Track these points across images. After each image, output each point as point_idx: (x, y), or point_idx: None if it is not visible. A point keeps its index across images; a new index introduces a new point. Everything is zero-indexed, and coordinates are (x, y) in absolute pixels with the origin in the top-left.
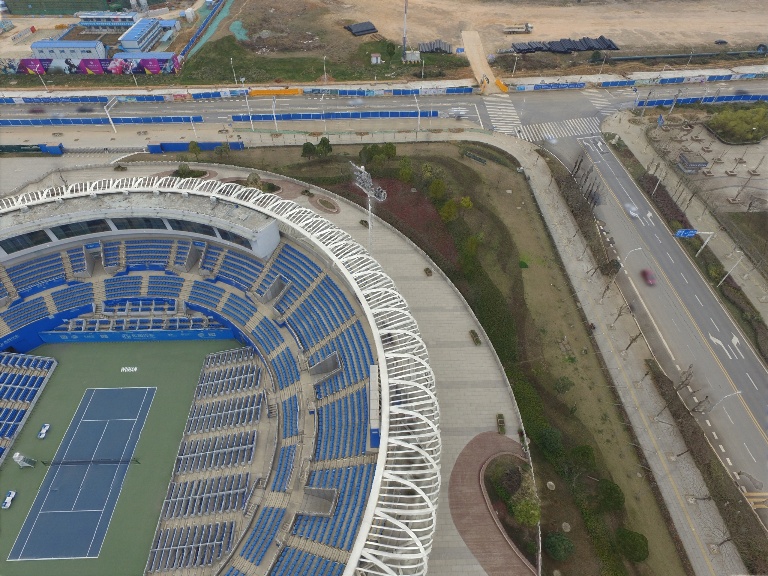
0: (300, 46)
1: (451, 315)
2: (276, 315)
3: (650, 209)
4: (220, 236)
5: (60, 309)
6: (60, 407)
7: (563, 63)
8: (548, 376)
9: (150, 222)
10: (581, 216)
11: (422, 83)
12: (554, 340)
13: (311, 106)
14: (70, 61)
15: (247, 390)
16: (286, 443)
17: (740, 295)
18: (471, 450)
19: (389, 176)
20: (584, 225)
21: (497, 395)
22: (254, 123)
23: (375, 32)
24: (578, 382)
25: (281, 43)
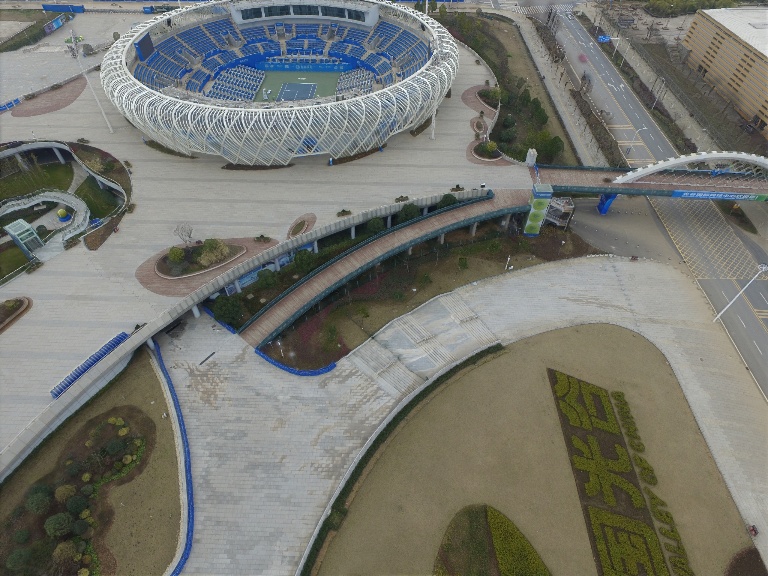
0: None
1: (466, 57)
2: None
3: (592, 41)
4: (348, 17)
5: (265, 51)
6: (273, 87)
7: None
8: (515, 89)
9: (311, 10)
10: (548, 41)
11: None
12: None
13: None
14: None
15: None
16: None
17: (631, 70)
18: (472, 88)
19: None
20: (549, 44)
21: (487, 77)
22: None
23: None
24: (531, 92)
25: None
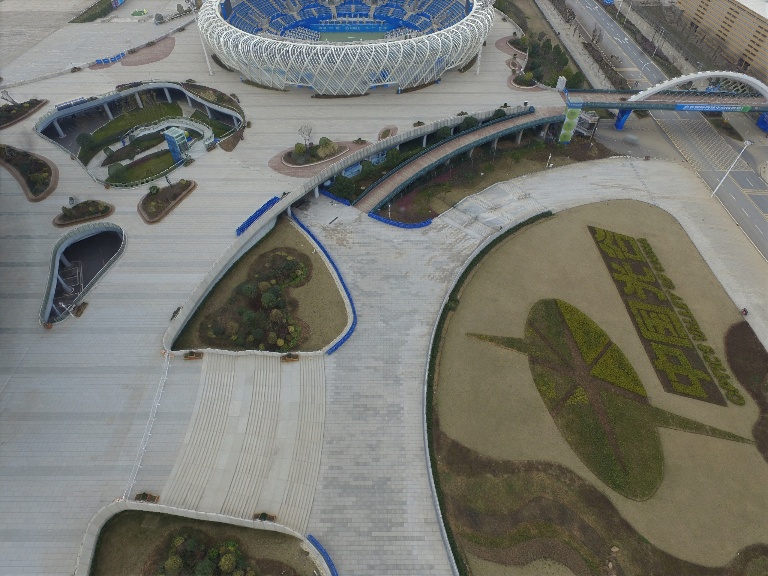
0: None
1: None
2: None
3: (597, 6)
4: None
5: None
6: None
7: None
8: (536, 42)
9: None
10: (559, 5)
11: None
12: None
13: None
14: None
15: None
16: None
17: (633, 26)
18: None
19: None
20: (560, 8)
21: (513, 30)
22: None
23: None
24: None
25: None
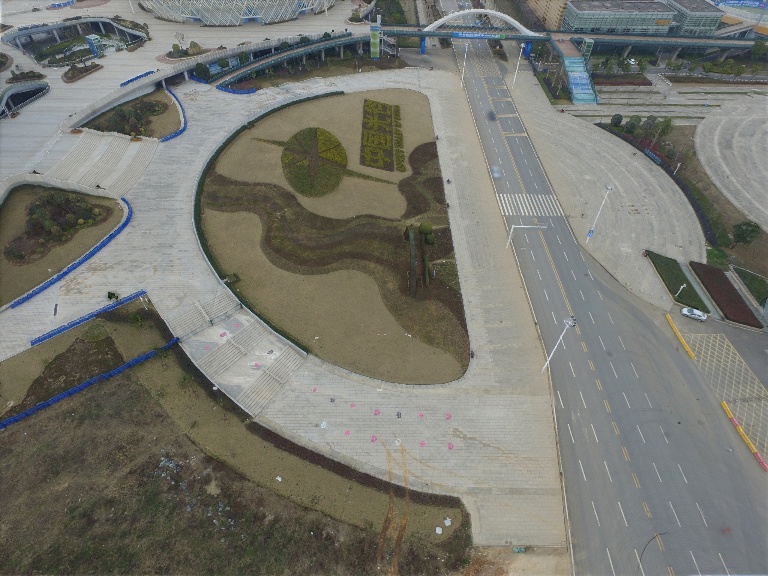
0: None
1: None
2: None
3: None
4: None
5: None
6: None
7: None
8: None
9: None
10: None
11: None
12: (401, 0)
13: None
14: None
15: None
16: None
17: None
18: None
19: None
20: None
21: None
22: None
23: None
24: None
25: None
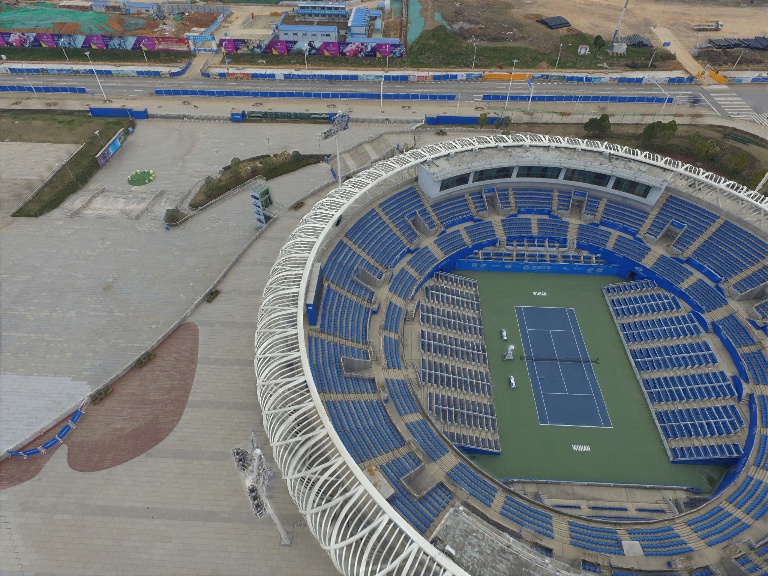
0: (506, 36)
1: None
2: (673, 254)
3: None
4: (611, 186)
5: (473, 241)
6: (502, 318)
7: (765, 59)
8: None
9: (545, 172)
10: None
11: (636, 73)
12: None
13: (546, 90)
14: (313, 43)
15: (668, 312)
16: (744, 351)
17: None
18: None
19: (669, 151)
20: None
21: None
22: (501, 103)
23: (569, 26)
24: None
25: (487, 33)
